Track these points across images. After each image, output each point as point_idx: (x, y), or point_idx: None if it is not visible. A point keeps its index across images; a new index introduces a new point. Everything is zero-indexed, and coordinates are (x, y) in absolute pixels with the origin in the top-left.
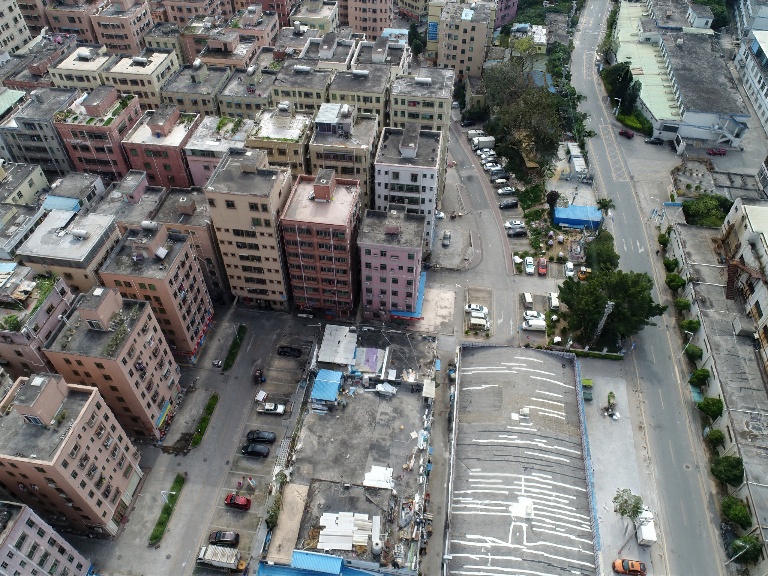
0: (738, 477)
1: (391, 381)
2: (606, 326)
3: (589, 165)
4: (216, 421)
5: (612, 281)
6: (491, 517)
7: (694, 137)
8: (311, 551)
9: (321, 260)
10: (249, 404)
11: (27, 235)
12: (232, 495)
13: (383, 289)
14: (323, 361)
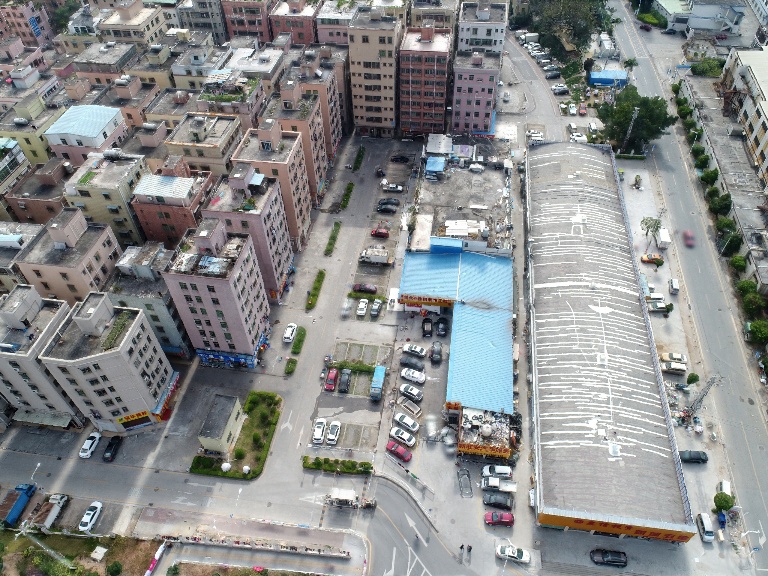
0: (728, 206)
1: (480, 162)
2: (633, 134)
3: (616, 48)
4: (355, 196)
5: (637, 102)
6: (558, 224)
7: (701, 28)
8: (442, 236)
9: (426, 85)
10: (376, 187)
11: (224, 63)
12: (376, 229)
13: (468, 111)
14: (430, 152)
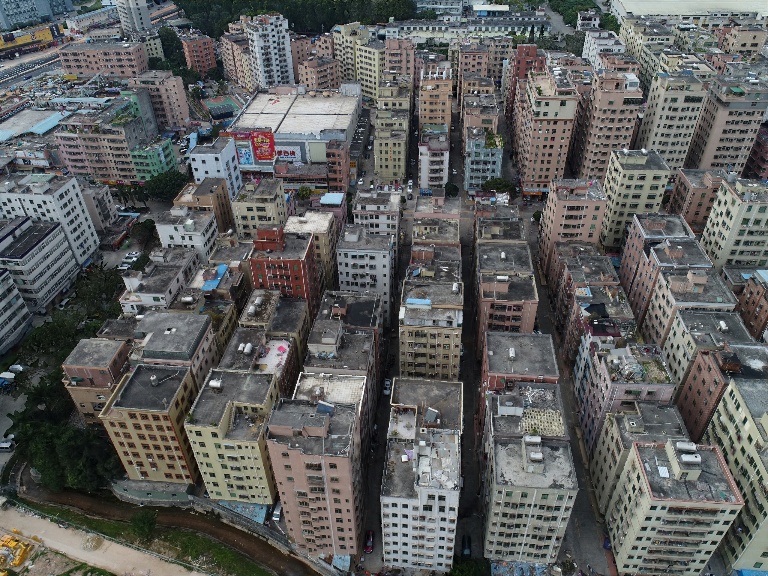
0: None
1: None
2: None
3: None
4: None
5: None
6: None
7: None
8: None
9: None
10: None
11: None
12: None
13: None
14: None
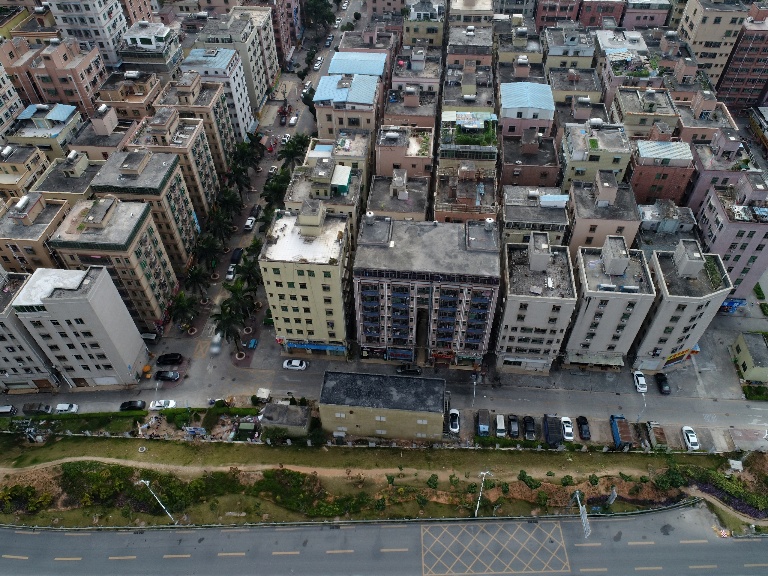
0: None
1: None
2: None
3: None
4: None
5: None
6: None
7: None
8: None
9: (757, 62)
10: None
11: None
12: None
13: None
14: None
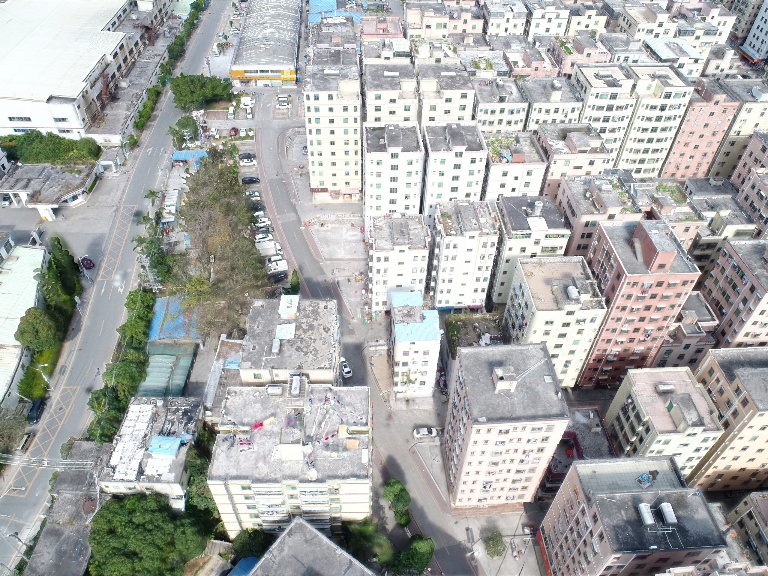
0: None
1: None
2: None
3: None
4: None
5: None
6: None
7: None
8: None
9: None
10: None
11: None
12: None
13: None
14: None
